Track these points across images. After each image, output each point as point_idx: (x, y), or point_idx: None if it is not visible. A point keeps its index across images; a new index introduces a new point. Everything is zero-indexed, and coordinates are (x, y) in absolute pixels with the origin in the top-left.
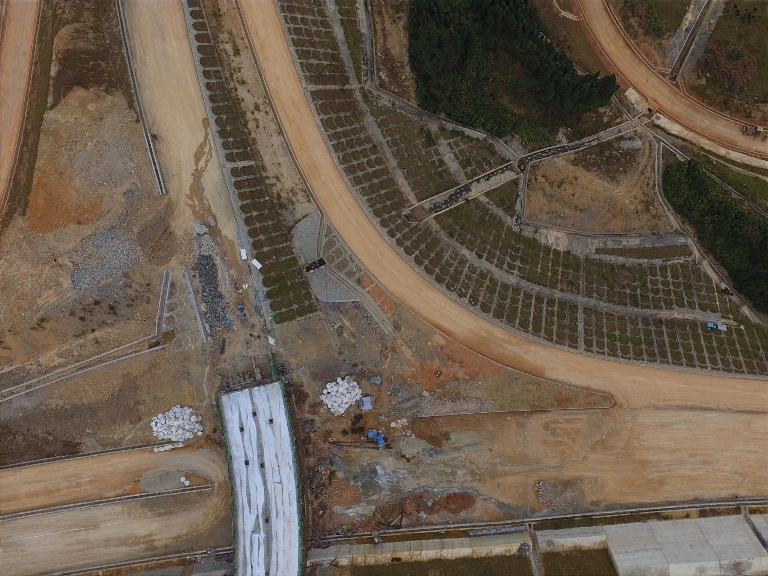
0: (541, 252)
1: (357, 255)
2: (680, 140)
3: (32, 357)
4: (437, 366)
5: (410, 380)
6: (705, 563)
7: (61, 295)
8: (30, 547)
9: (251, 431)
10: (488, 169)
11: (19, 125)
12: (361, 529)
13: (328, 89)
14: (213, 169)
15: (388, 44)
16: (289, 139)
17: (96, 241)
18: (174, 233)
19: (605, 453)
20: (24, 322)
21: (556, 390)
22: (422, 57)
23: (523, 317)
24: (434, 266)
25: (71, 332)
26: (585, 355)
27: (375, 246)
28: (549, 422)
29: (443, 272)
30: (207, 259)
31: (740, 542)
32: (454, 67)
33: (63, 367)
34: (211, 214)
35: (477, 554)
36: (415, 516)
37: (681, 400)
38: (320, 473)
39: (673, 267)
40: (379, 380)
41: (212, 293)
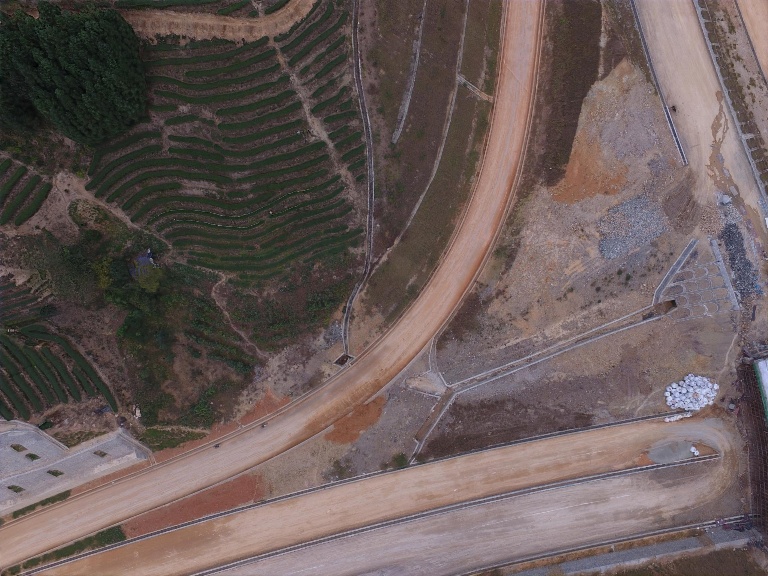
0: None
1: None
2: None
3: (538, 329)
4: None
5: None
6: None
7: (589, 265)
8: (540, 523)
9: None
10: None
11: (529, 98)
12: None
13: None
14: (731, 140)
15: None
16: None
17: (626, 211)
18: (697, 203)
19: None
20: (551, 292)
21: None
22: None
23: None
24: None
25: (581, 303)
26: None
27: None
28: None
29: None
30: (734, 228)
31: None
32: None
33: (566, 339)
34: (732, 184)
35: None
36: None
37: None
38: None
39: None
40: None
41: (742, 261)
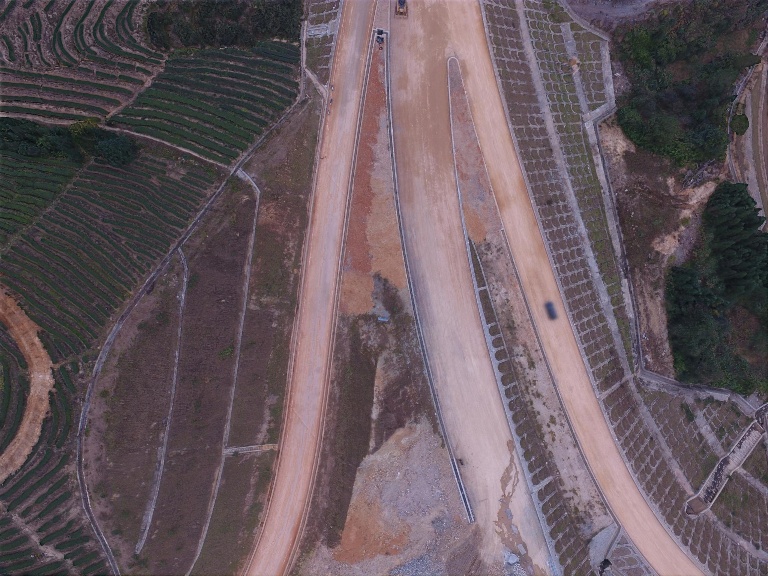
0: None
1: (654, 566)
2: None
3: None
4: None
5: None
6: None
7: None
8: None
9: None
10: (737, 433)
11: (315, 445)
12: None
13: (613, 391)
14: (521, 494)
15: (651, 324)
16: (583, 450)
17: (406, 574)
18: (483, 562)
19: None
20: None
21: None
22: (691, 343)
23: None
24: (725, 570)
25: None
26: None
27: (670, 556)
28: None
29: (733, 575)
30: None
31: None
32: None
33: None
34: (521, 542)
35: None
36: None
37: None
38: None
39: None
40: None
41: None
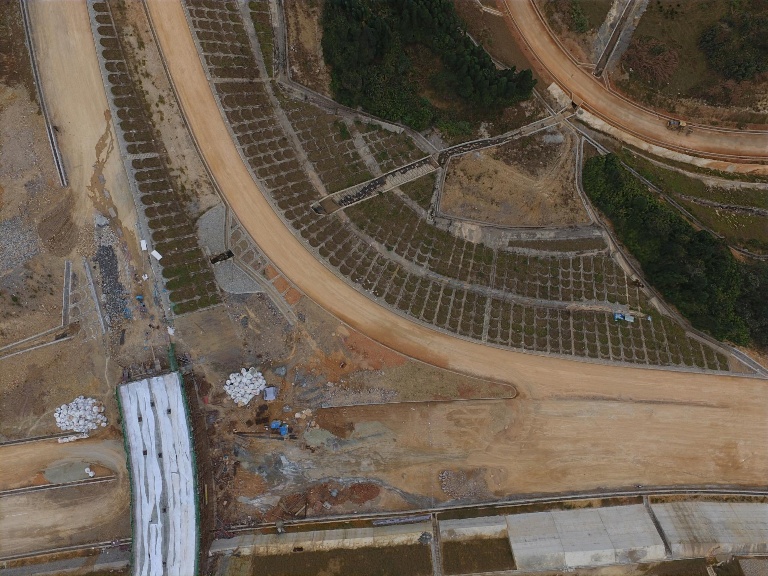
0: (454, 245)
1: (262, 247)
2: (602, 134)
3: None
4: (341, 357)
5: (314, 371)
6: (600, 551)
7: None
8: None
9: (149, 421)
10: (405, 162)
11: None
12: (266, 519)
13: (235, 82)
14: (114, 161)
15: (301, 38)
16: (194, 131)
17: None
18: (75, 224)
19: (508, 443)
20: None
21: (459, 381)
22: (333, 51)
23: (429, 308)
24: (340, 258)
25: None
26: (488, 346)
27: (280, 238)
28: (453, 412)
29: (349, 264)
30: (107, 250)
31: (638, 531)
32: (373, 61)
33: None
34: (112, 205)
35: (379, 544)
36: (319, 506)
37: (583, 390)
38: (224, 463)
39: (586, 260)
40: (284, 371)
41: (112, 284)
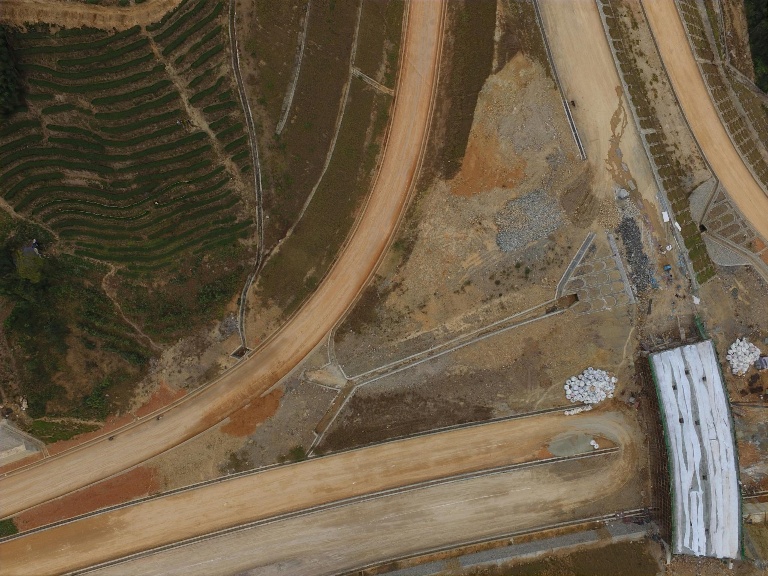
0: None
1: (749, 220)
2: None
3: (439, 322)
4: None
5: None
6: None
7: (486, 258)
8: (439, 516)
9: (685, 389)
10: None
11: (430, 91)
12: (762, 487)
13: (708, 63)
14: (629, 135)
15: (734, 24)
16: (683, 109)
17: (523, 204)
18: (595, 197)
19: None
20: (449, 285)
21: None
22: None
23: None
24: None
25: (481, 297)
26: None
27: (765, 212)
28: None
29: None
30: (631, 222)
31: None
32: None
33: (467, 332)
34: (630, 178)
35: None
36: None
37: None
38: None
39: None
40: None
41: (638, 255)
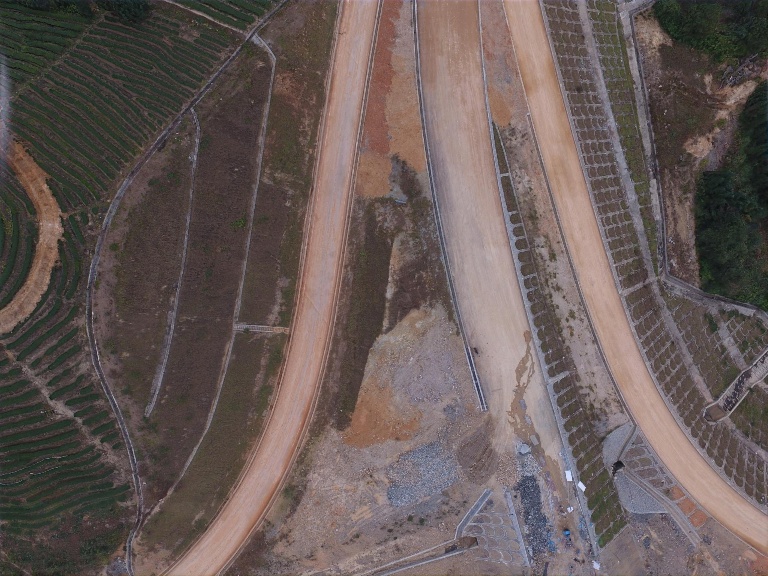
0: None
1: (668, 467)
2: None
3: (331, 563)
4: None
5: None
6: None
7: (376, 511)
8: None
9: None
10: (761, 349)
11: (327, 330)
12: None
13: (636, 290)
14: (536, 385)
15: (678, 228)
16: (602, 346)
17: (416, 459)
18: (494, 451)
19: None
20: (337, 537)
21: None
22: (720, 248)
23: None
24: (741, 475)
25: (374, 541)
26: None
27: (686, 457)
28: None
29: (749, 481)
30: (531, 480)
31: None
32: None
33: (361, 572)
34: (534, 433)
35: None
36: None
37: None
38: None
39: None
40: None
41: (536, 516)
